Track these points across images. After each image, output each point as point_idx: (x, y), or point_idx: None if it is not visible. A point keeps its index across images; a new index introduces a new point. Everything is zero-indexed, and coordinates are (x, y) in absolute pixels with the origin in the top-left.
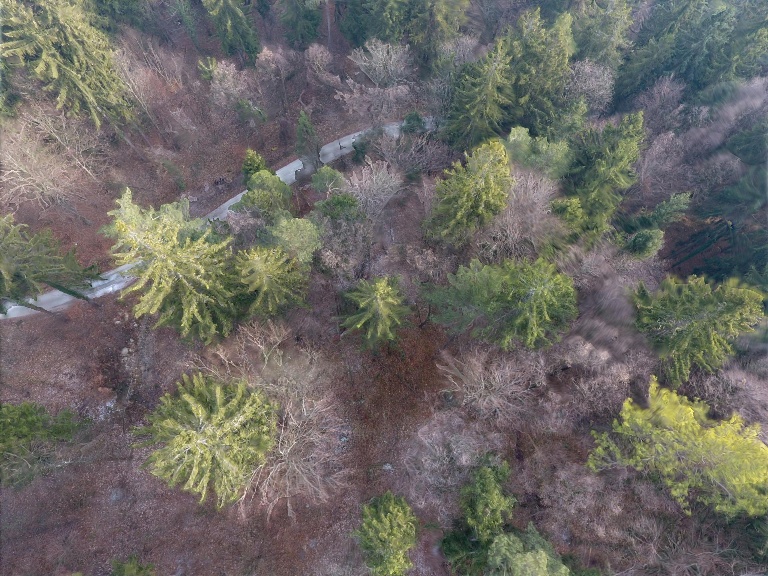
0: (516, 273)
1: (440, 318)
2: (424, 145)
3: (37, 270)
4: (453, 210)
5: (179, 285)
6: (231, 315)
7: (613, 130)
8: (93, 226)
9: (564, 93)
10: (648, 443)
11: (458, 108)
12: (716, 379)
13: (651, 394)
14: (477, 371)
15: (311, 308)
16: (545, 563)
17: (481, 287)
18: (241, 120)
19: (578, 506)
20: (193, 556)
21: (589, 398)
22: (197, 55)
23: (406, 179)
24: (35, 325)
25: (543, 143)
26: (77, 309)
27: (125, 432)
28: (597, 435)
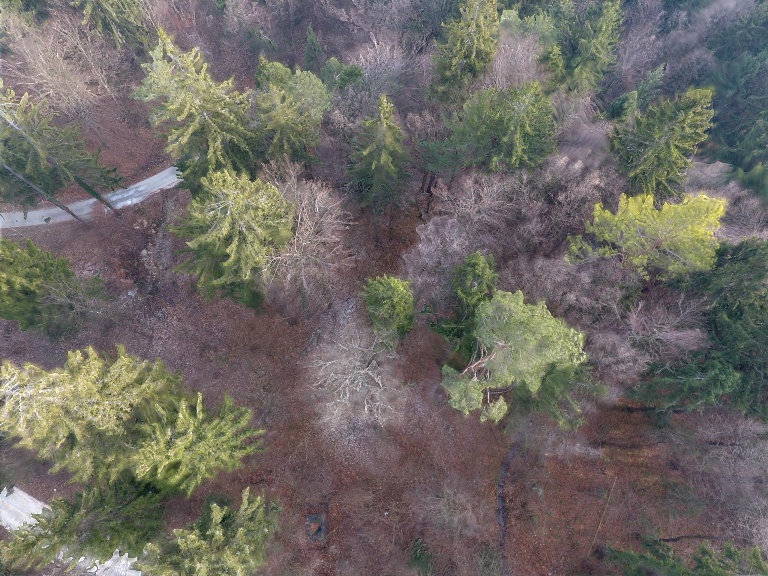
0: (502, 95)
1: (436, 165)
2: (424, 46)
3: (67, 159)
4: (448, 60)
5: (205, 125)
6: (249, 168)
7: (594, 10)
8: (112, 149)
9: (554, 1)
10: (614, 230)
11: (456, 17)
12: (679, 199)
13: (620, 207)
14: (468, 189)
15: (321, 161)
16: (522, 299)
17: (472, 111)
18: (252, 50)
19: (553, 280)
20: (211, 408)
21: (566, 211)
22: (208, 3)
23: (407, 83)
24: (60, 231)
25: (531, 21)
26: (101, 207)
27: (146, 317)
28: (572, 240)
